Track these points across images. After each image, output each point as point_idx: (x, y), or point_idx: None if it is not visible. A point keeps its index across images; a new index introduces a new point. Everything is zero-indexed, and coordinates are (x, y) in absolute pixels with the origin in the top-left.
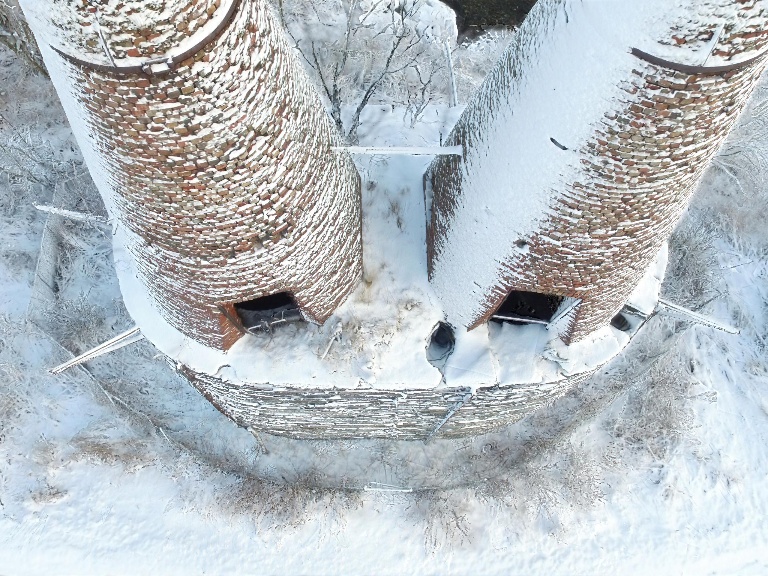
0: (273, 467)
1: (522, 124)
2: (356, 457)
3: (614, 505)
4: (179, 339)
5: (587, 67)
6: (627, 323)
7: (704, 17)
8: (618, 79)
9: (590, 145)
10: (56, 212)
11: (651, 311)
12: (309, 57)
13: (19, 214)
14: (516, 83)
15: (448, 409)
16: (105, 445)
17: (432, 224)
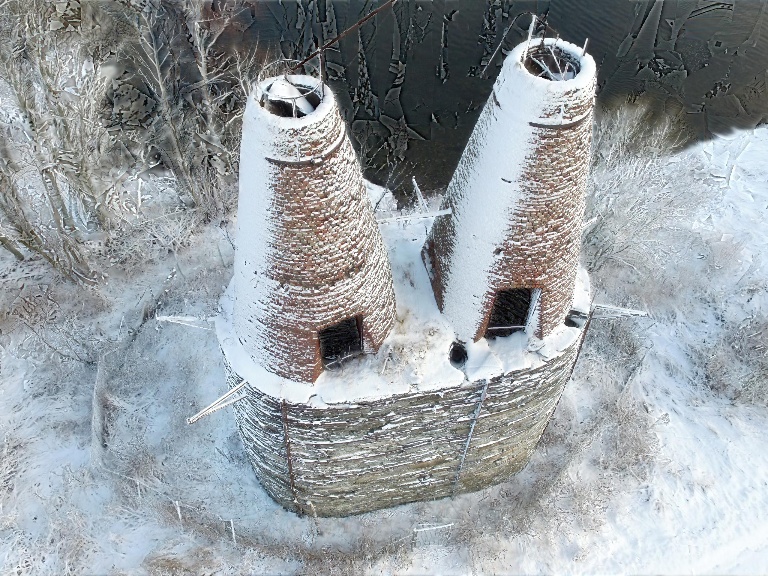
0: (329, 545)
1: (485, 177)
2: (398, 522)
3: (619, 526)
4: (278, 382)
5: (511, 137)
6: (576, 324)
7: (555, 103)
8: (527, 138)
9: (522, 176)
10: (171, 320)
11: (589, 311)
12: None
13: (62, 391)
14: (477, 159)
15: (471, 419)
16: (175, 560)
17: (437, 271)
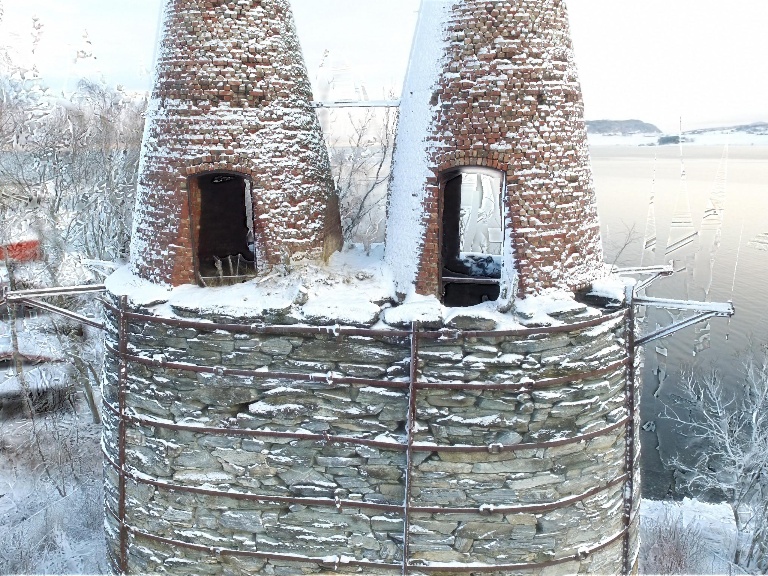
0: None
1: (421, 5)
2: None
3: None
4: None
5: None
6: None
7: None
8: None
9: None
10: (94, 264)
11: (621, 296)
12: None
13: None
14: None
15: (399, 444)
16: None
17: None
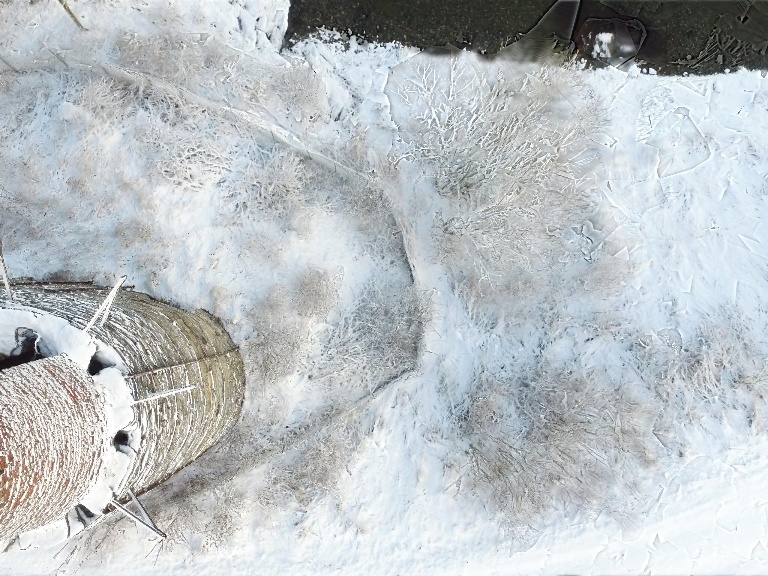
0: None
1: None
2: None
3: (256, 536)
4: None
5: None
6: None
7: None
8: None
9: None
10: None
11: (99, 513)
12: (106, 50)
13: None
14: None
15: None
16: None
17: None
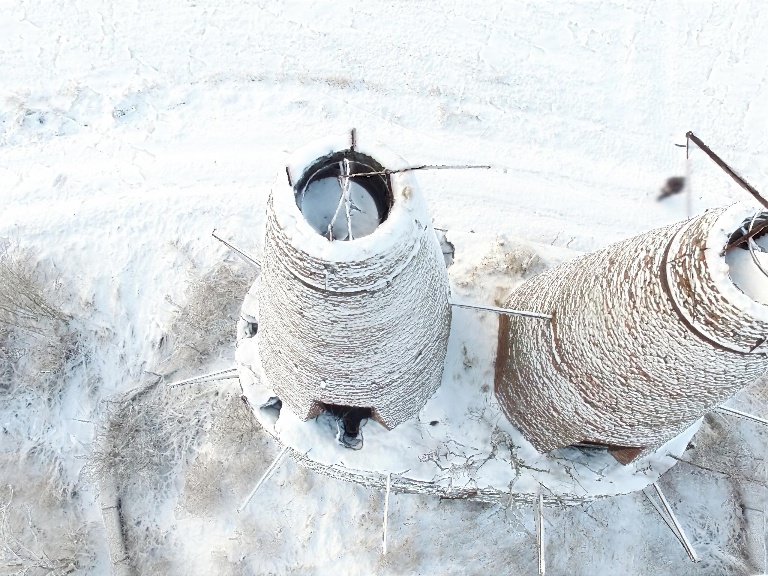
0: None
1: None
2: None
3: None
4: None
5: None
6: None
7: None
8: None
9: None
10: None
11: None
12: None
13: None
14: None
15: None
16: None
17: None
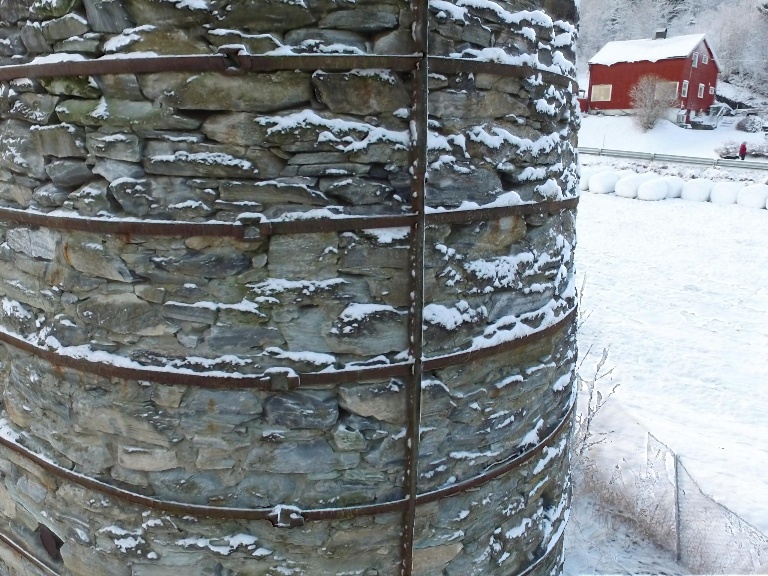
0: None
1: None
2: None
3: None
4: None
5: None
6: None
7: None
8: None
9: None
10: None
11: None
12: None
13: None
14: None
15: None
16: None
17: None
